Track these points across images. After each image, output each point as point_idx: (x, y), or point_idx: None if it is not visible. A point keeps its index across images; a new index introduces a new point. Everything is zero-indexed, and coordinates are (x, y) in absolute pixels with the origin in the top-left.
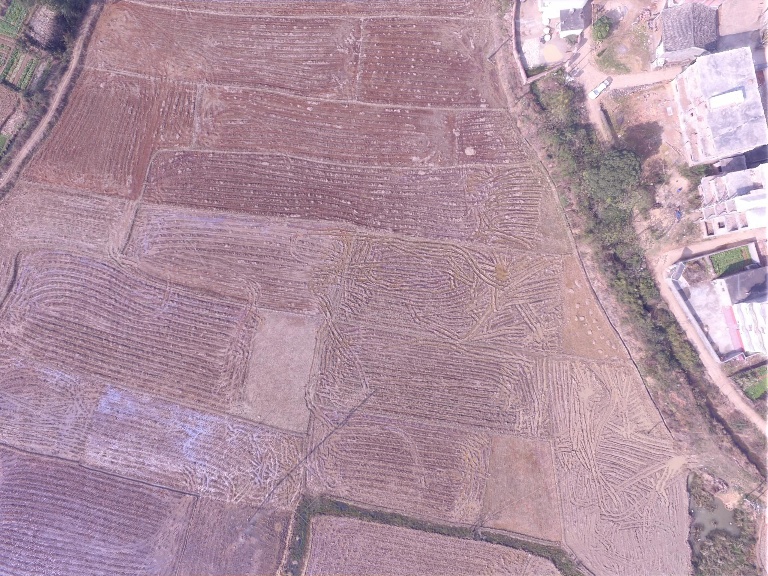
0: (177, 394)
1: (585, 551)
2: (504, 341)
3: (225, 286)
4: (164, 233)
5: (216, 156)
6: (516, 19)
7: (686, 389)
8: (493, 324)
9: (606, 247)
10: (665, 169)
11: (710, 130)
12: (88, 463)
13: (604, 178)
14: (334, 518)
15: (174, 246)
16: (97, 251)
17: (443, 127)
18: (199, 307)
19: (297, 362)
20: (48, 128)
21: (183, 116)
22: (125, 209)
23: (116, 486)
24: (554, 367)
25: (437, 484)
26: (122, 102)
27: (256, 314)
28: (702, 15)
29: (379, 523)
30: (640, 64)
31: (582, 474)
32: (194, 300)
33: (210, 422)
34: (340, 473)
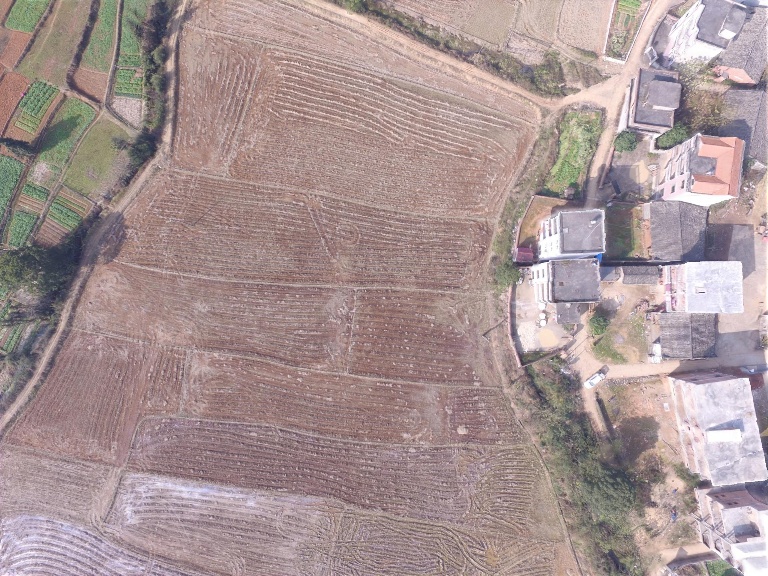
0: None
1: None
2: None
3: (208, 560)
4: (148, 502)
5: (203, 425)
6: (512, 301)
7: None
8: None
9: (599, 547)
10: (661, 465)
11: (707, 461)
12: None
13: (597, 500)
14: None
15: (158, 516)
16: (79, 519)
17: (435, 404)
18: None
19: None
20: (33, 391)
21: (171, 382)
22: (109, 476)
23: None
24: None
25: None
26: (109, 366)
27: None
28: (701, 321)
29: None
30: (637, 355)
31: None
32: (176, 573)
33: None
34: None
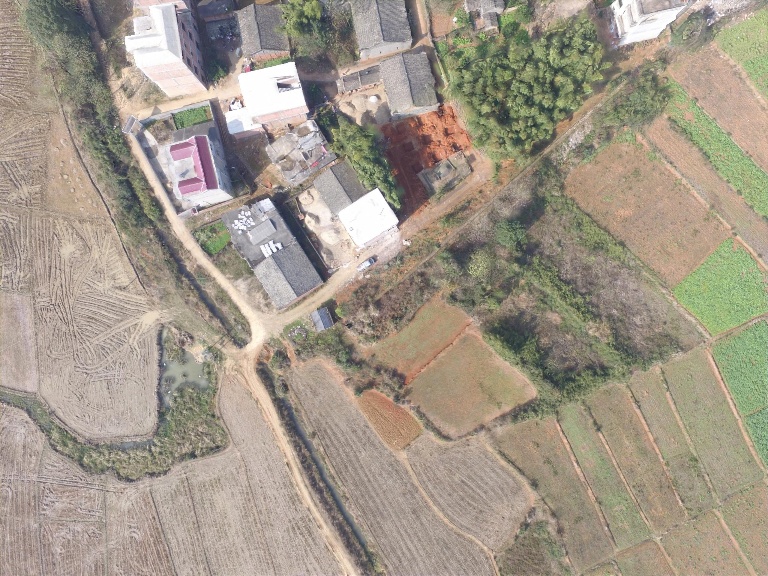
0: None
1: (58, 402)
2: None
3: None
4: None
5: None
6: None
7: (156, 245)
8: None
9: None
10: None
11: None
12: None
13: None
14: None
15: None
16: None
17: None
18: None
19: None
20: None
21: None
22: None
23: None
24: (37, 224)
25: None
26: None
27: None
28: None
29: None
30: None
31: (59, 328)
32: None
33: None
34: None
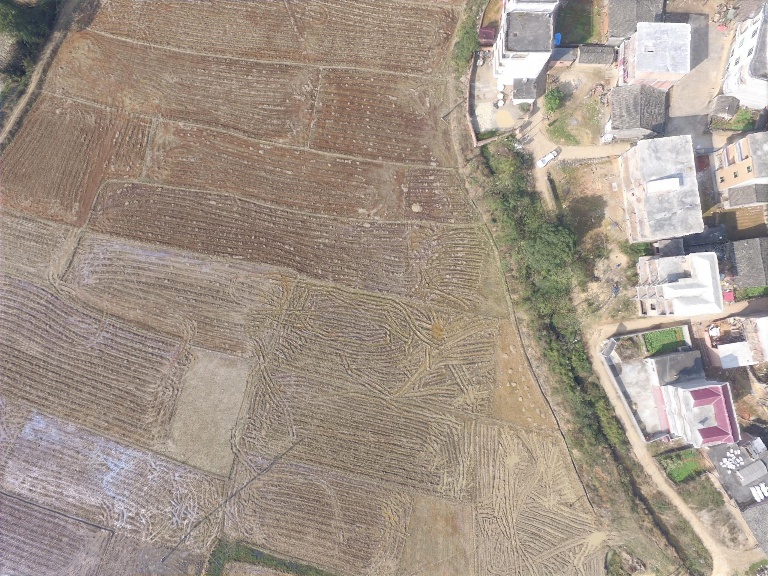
0: (102, 426)
1: None
2: (434, 400)
3: (161, 321)
4: (105, 263)
5: (164, 191)
6: (472, 82)
7: (611, 465)
8: (425, 382)
9: (541, 316)
10: (606, 243)
11: (646, 213)
12: (6, 489)
13: (539, 251)
14: (248, 566)
15: (114, 277)
16: (37, 275)
17: (392, 181)
18: (133, 340)
19: (226, 404)
20: None
21: (135, 148)
22: (69, 236)
23: (32, 515)
24: (482, 431)
25: (355, 540)
26: (76, 129)
27: (189, 352)
28: (651, 96)
29: (293, 575)
30: (590, 137)
31: (501, 542)
32: (129, 333)
33: (133, 457)
34: (259, 520)
